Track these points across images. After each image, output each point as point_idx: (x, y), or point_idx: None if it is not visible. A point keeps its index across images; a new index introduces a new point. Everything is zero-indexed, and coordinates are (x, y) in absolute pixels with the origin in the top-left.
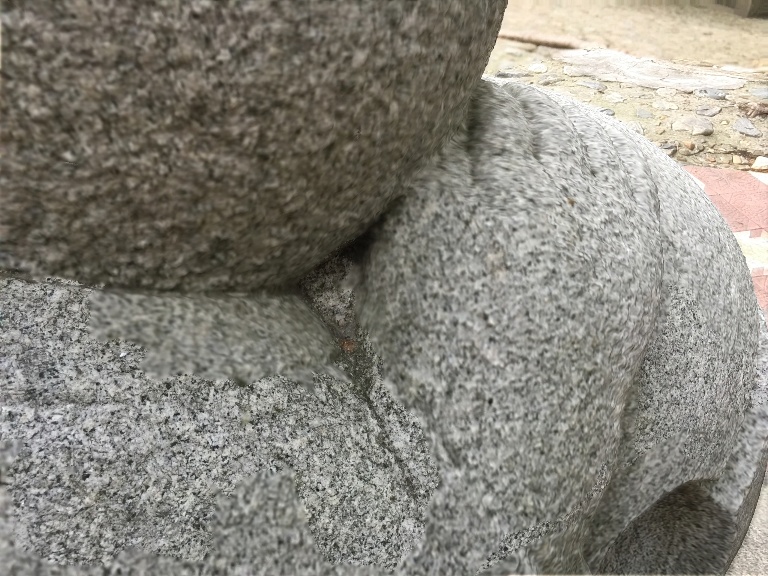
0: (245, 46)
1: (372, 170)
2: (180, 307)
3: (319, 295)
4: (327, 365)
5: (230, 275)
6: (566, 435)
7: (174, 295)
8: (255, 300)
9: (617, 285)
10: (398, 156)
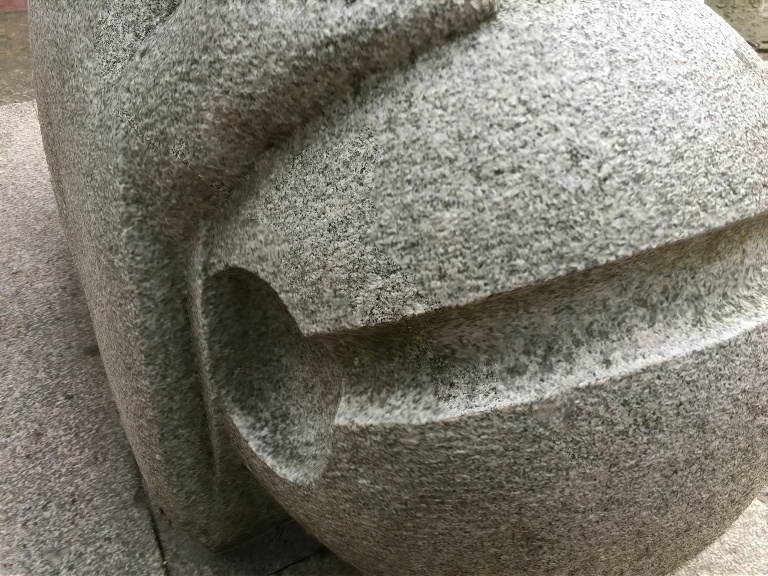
0: None
1: None
2: None
3: None
4: None
5: None
6: (166, 84)
7: None
8: None
9: (240, 18)
10: None
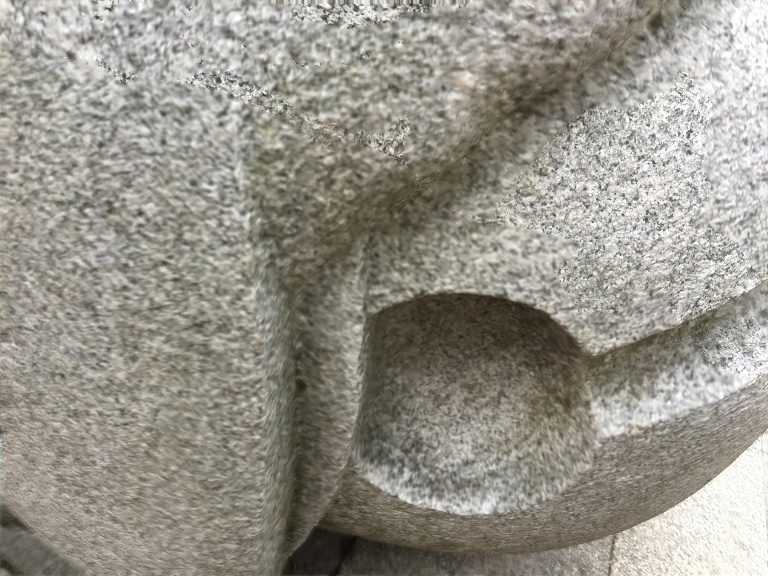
0: None
1: None
2: None
3: None
4: None
5: None
6: (367, 24)
7: None
8: None
9: None
10: None
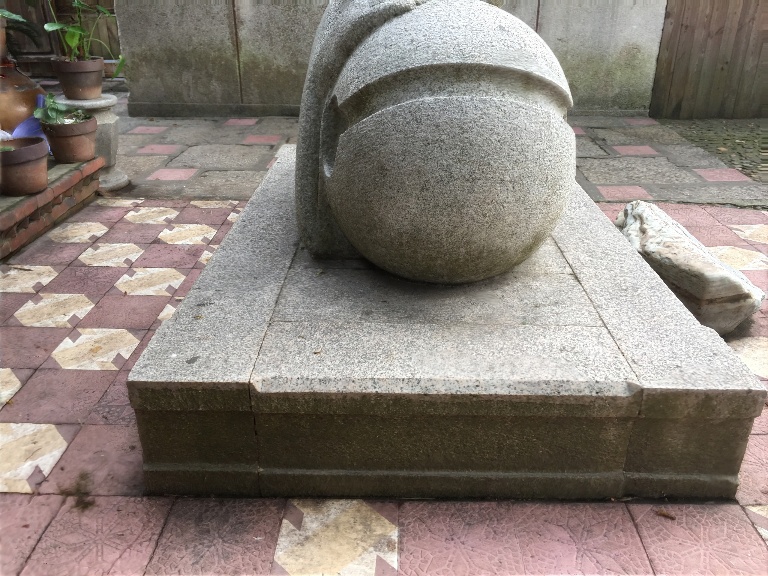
0: None
1: None
2: None
3: None
4: None
5: None
6: None
7: None
8: None
9: None
10: None
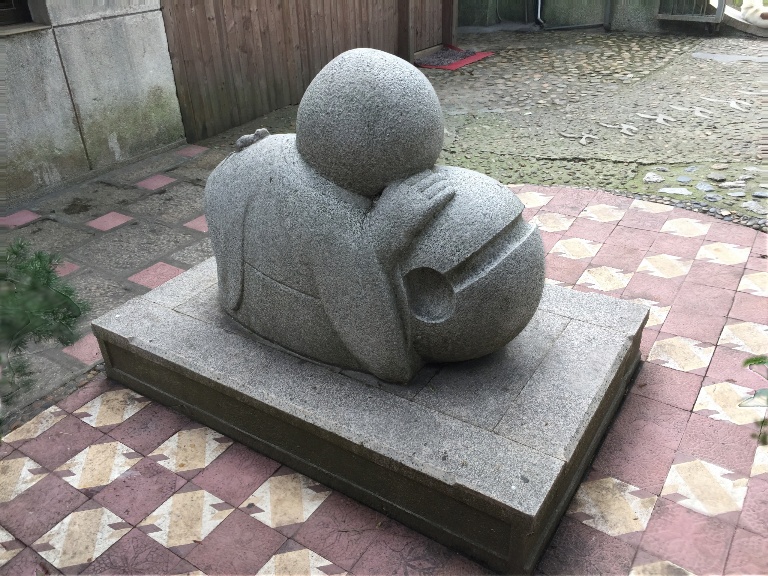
0: (349, 158)
1: (373, 178)
2: (345, 191)
3: (374, 201)
4: (363, 208)
5: (354, 189)
6: (387, 230)
7: (345, 189)
8: (358, 195)
9: (407, 210)
10: (378, 177)
